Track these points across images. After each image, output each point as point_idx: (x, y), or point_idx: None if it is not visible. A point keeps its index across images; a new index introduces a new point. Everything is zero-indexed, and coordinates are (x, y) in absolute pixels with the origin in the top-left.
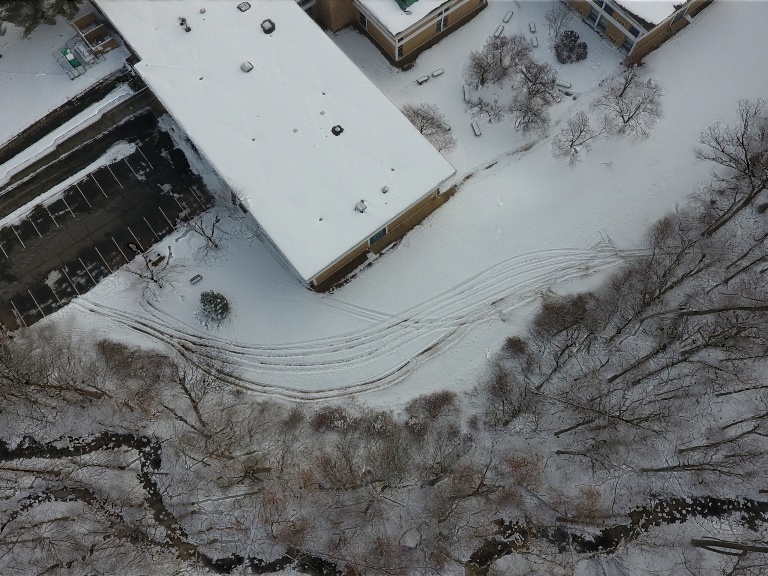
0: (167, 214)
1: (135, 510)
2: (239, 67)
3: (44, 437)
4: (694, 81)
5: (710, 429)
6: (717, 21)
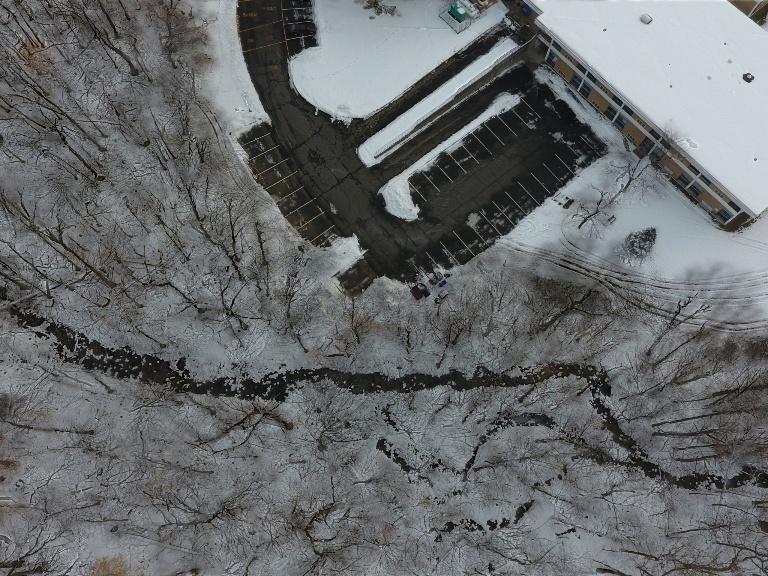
0: (565, 160)
1: (599, 432)
2: (639, 19)
3: (500, 366)
4: None
5: None
6: None
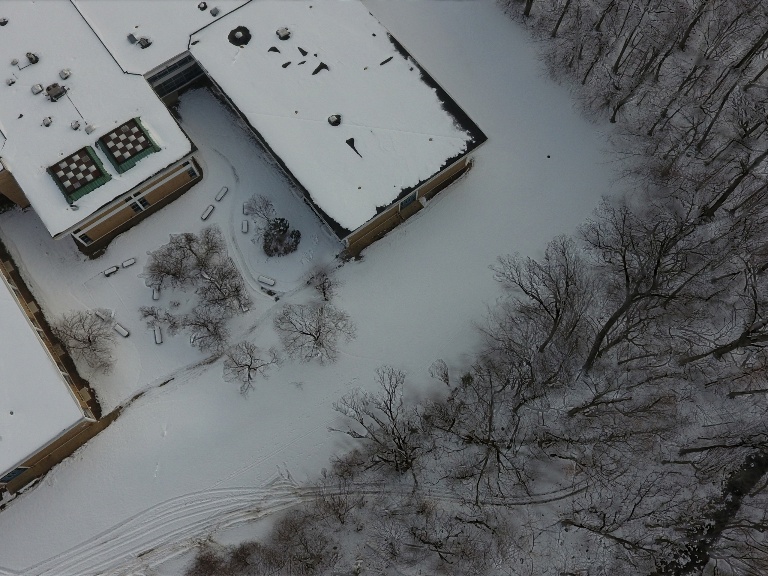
0: None
1: None
2: None
3: None
4: (415, 280)
5: None
6: (454, 206)
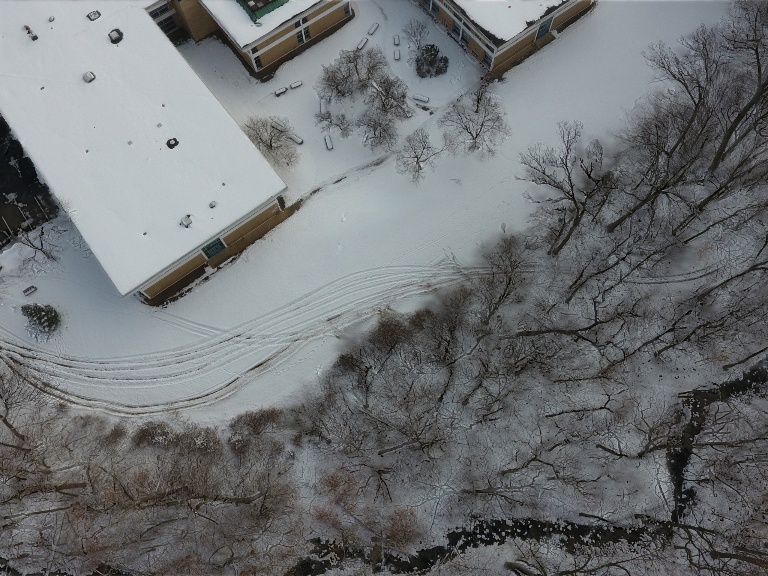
0: (9, 224)
1: None
2: (81, 77)
3: None
4: (554, 97)
5: (536, 451)
6: (583, 37)
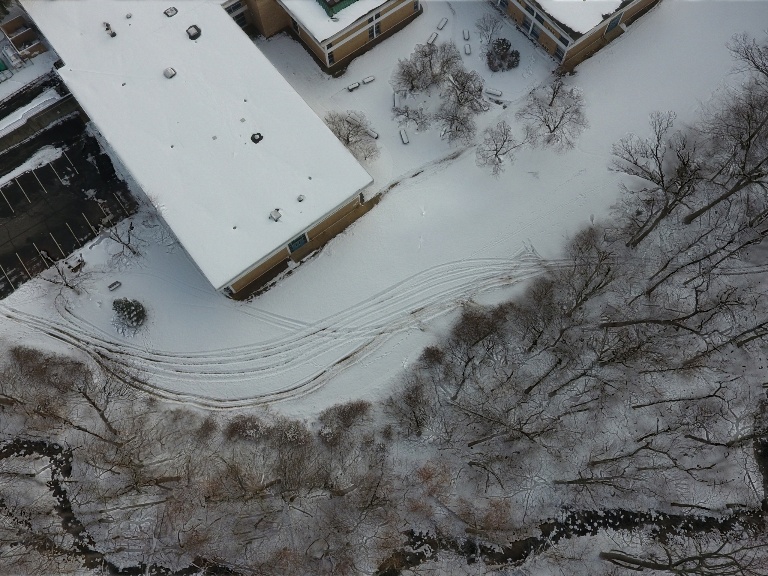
0: (90, 220)
1: (43, 518)
2: (162, 73)
3: None
4: (626, 90)
5: (625, 441)
6: (652, 30)
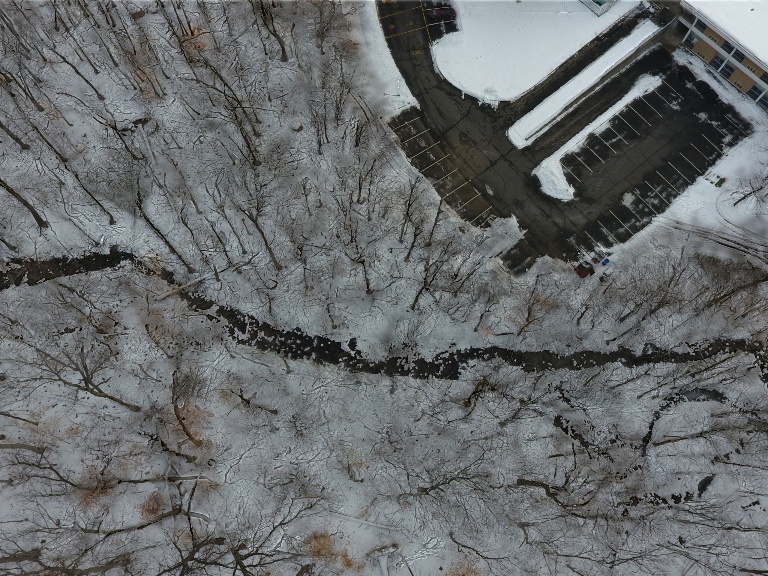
0: (712, 140)
1: None
2: None
3: (669, 343)
4: None
5: None
6: None
